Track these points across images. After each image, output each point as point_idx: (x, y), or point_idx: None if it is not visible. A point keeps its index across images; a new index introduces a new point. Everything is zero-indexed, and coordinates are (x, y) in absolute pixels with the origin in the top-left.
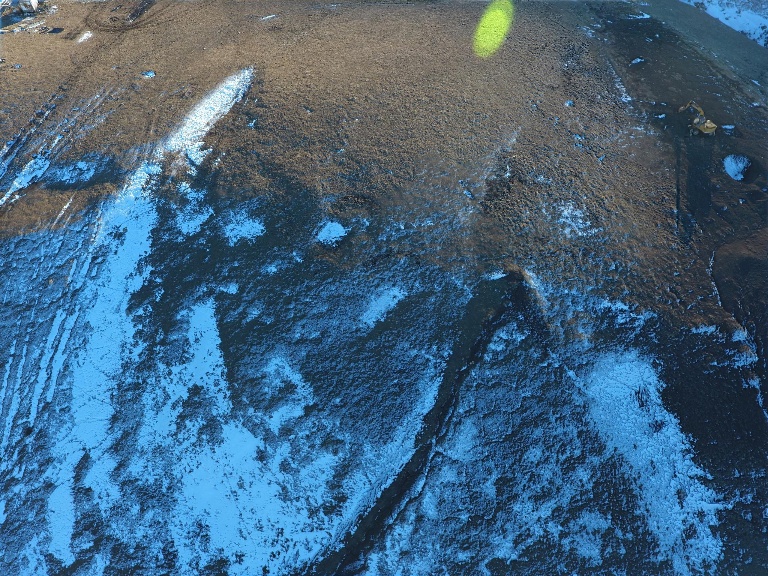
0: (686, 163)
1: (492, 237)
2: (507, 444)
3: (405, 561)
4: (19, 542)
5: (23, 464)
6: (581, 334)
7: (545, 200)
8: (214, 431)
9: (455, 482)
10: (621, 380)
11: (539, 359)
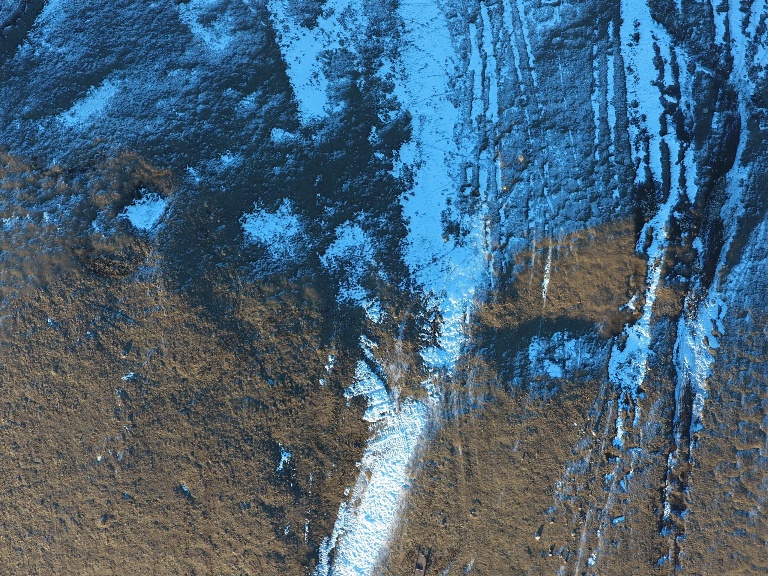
0: None
1: None
2: None
3: None
4: None
5: None
6: None
7: None
8: None
9: None
10: None
11: None
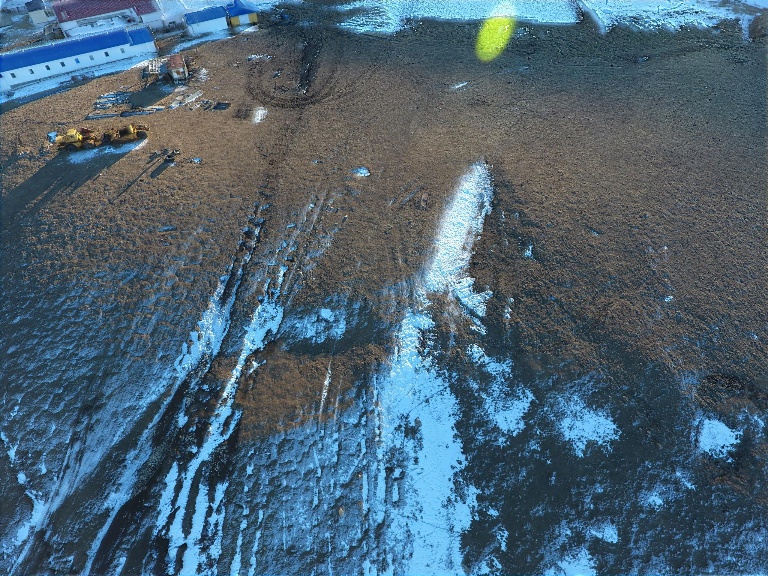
0: None
1: None
2: None
3: None
4: None
5: None
6: None
7: None
8: None
9: None
10: None
11: None
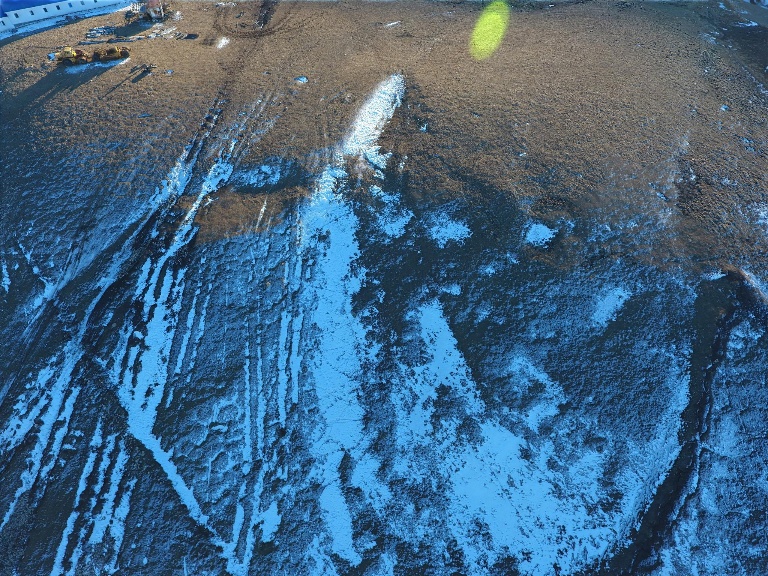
0: None
1: (699, 238)
2: None
3: (698, 556)
4: (301, 543)
5: (285, 465)
6: None
7: (738, 202)
8: (473, 430)
9: (728, 478)
10: None
11: None
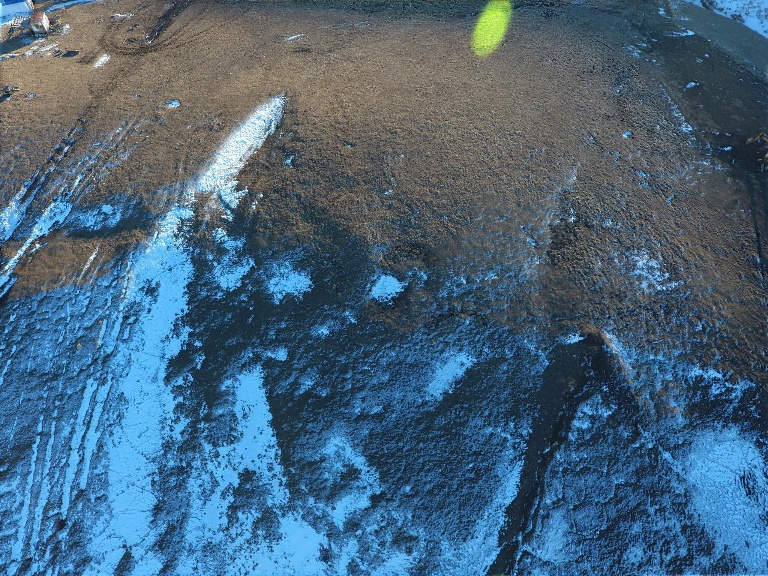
0: (761, 203)
1: (564, 293)
2: (603, 542)
3: None
4: None
5: (56, 565)
6: (673, 408)
7: (616, 248)
8: (270, 525)
9: None
10: (723, 462)
11: (630, 438)
